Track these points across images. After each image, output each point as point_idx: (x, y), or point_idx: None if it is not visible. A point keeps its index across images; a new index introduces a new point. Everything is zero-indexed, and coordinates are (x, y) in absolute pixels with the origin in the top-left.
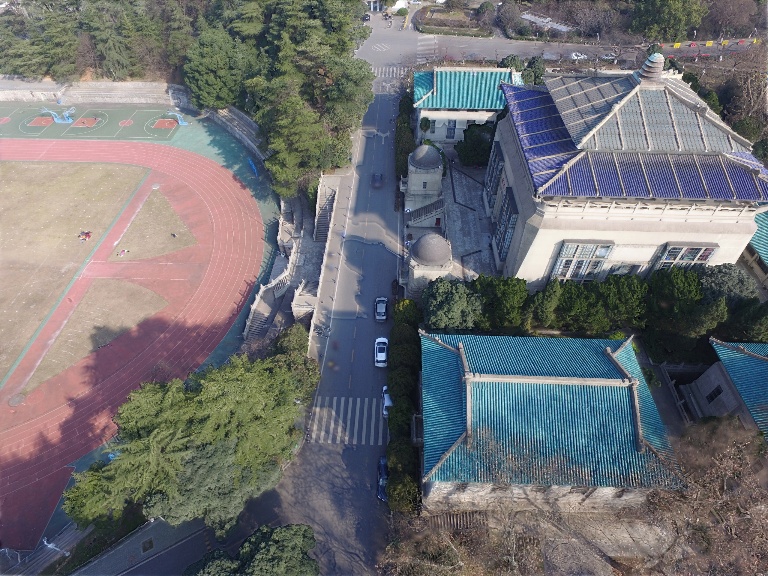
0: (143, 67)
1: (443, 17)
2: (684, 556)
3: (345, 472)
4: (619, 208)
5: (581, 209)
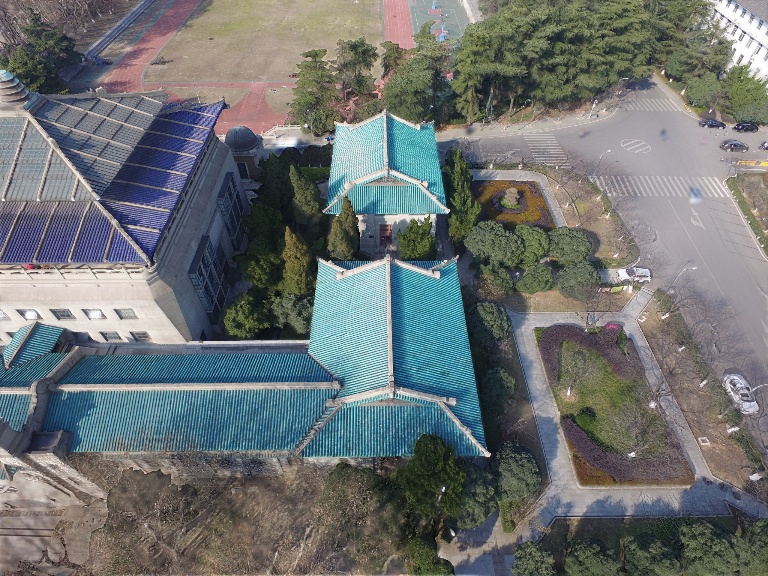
0: None
1: None
2: None
3: None
4: None
5: None
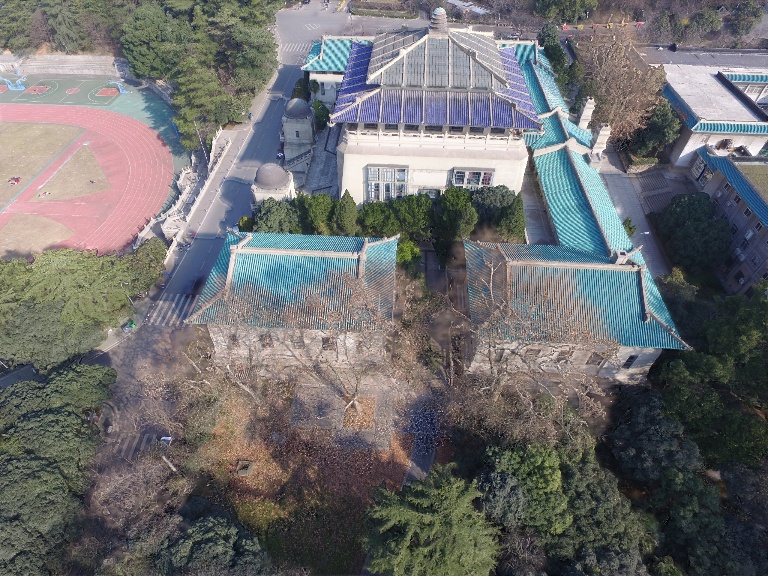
0: (92, 41)
1: (376, 1)
2: (407, 398)
3: (169, 345)
4: (408, 136)
5: (377, 137)
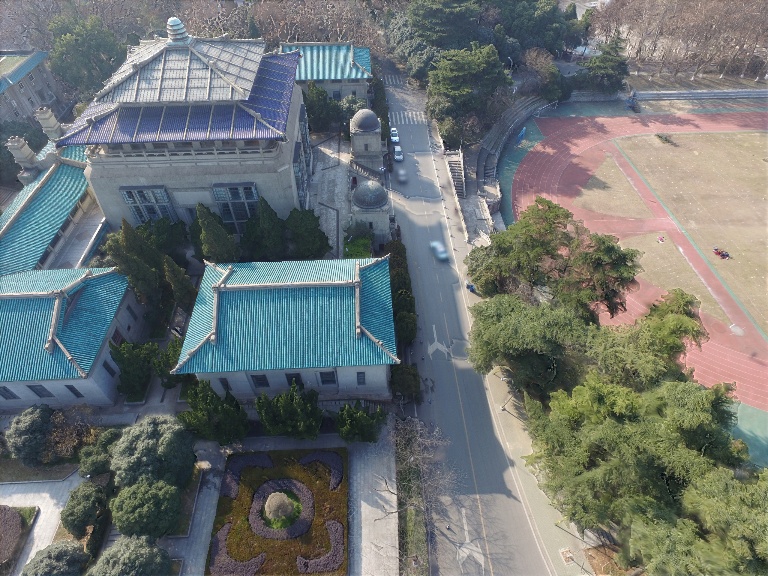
0: None
1: None
2: None
3: None
4: None
5: None
